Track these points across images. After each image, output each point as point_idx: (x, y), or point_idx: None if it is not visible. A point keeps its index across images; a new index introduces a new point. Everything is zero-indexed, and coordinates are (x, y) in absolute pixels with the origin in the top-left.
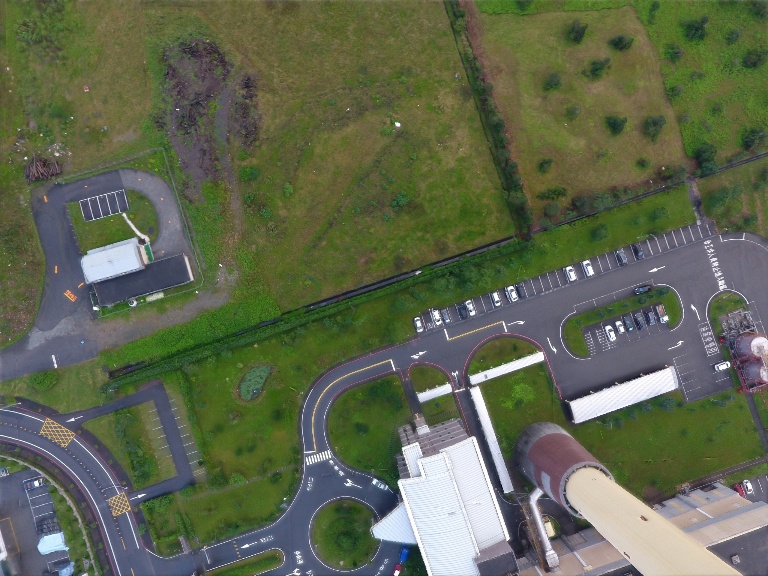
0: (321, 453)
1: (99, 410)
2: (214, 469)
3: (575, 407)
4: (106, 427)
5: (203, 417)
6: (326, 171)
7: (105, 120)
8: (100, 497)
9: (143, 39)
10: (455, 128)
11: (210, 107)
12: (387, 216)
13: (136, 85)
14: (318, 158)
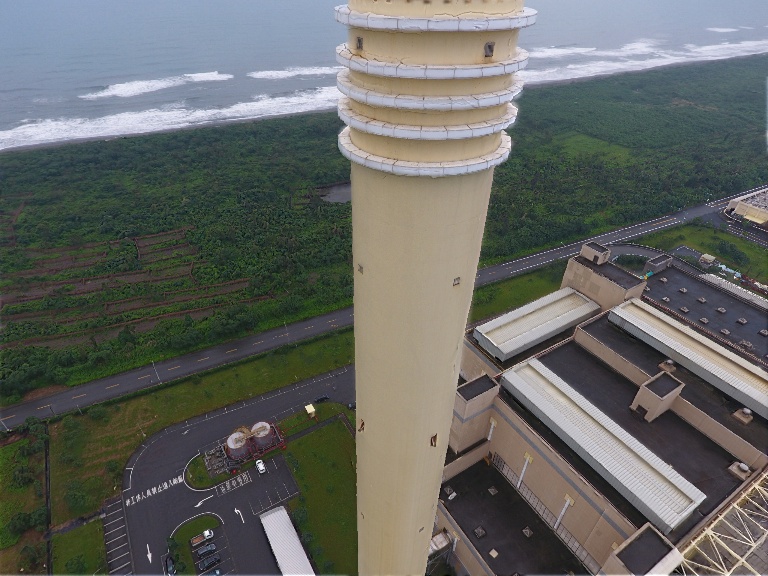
0: None
1: None
2: None
3: None
4: None
5: None
6: None
7: None
8: None
9: None
10: None
11: None
12: None
13: None
14: None
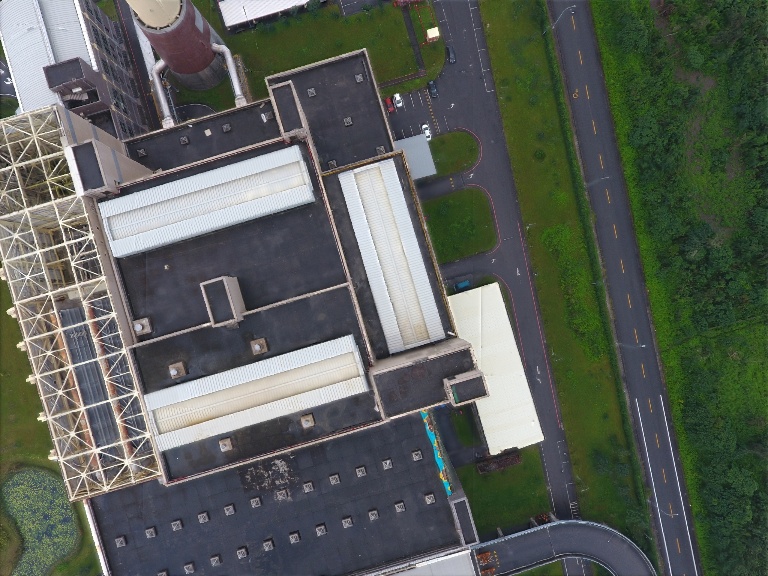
0: None
1: None
2: None
3: (224, 7)
4: None
5: None
6: None
7: None
8: None
9: None
10: None
11: None
12: None
13: None
14: None
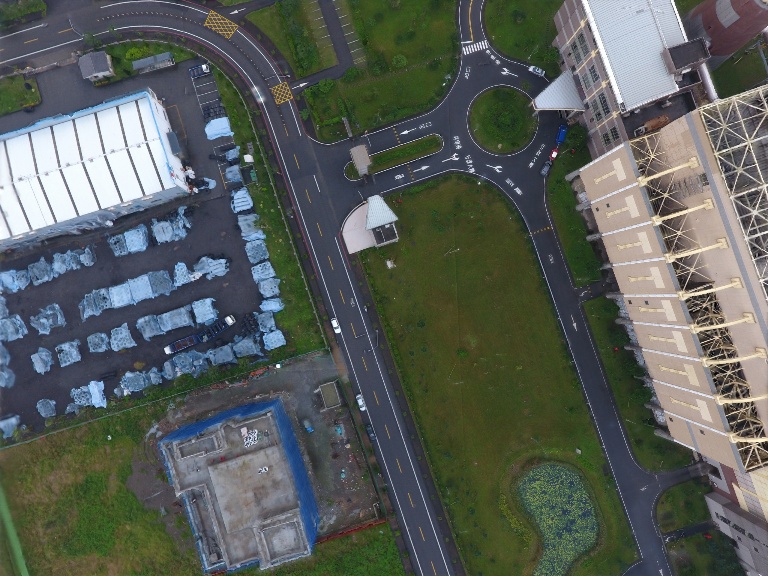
0: (478, 43)
1: (261, 2)
2: (376, 54)
3: None
4: (268, 19)
5: (363, 7)
6: None
7: None
8: (263, 86)
9: None
10: None
11: None
12: None
13: None
14: None
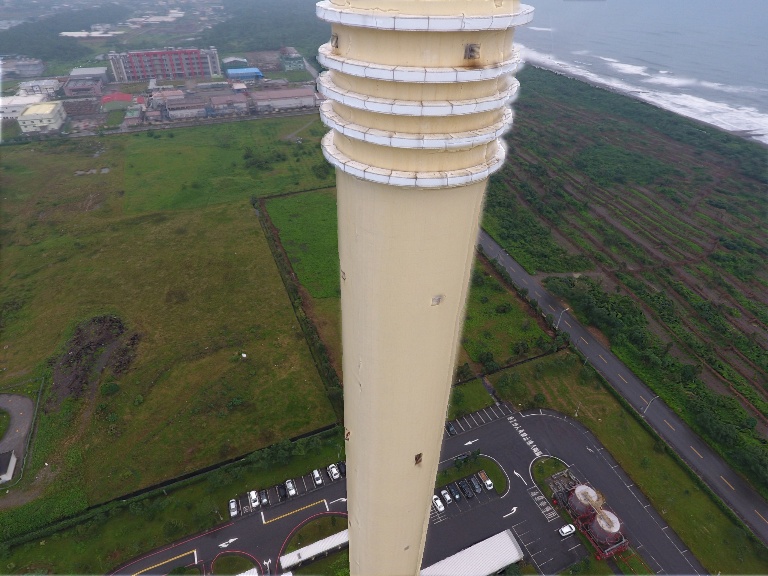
0: None
1: None
2: None
3: None
4: None
5: None
6: (177, 386)
7: (8, 364)
8: None
9: (68, 320)
10: (289, 355)
11: (97, 351)
12: (221, 413)
13: (47, 343)
14: (173, 378)
